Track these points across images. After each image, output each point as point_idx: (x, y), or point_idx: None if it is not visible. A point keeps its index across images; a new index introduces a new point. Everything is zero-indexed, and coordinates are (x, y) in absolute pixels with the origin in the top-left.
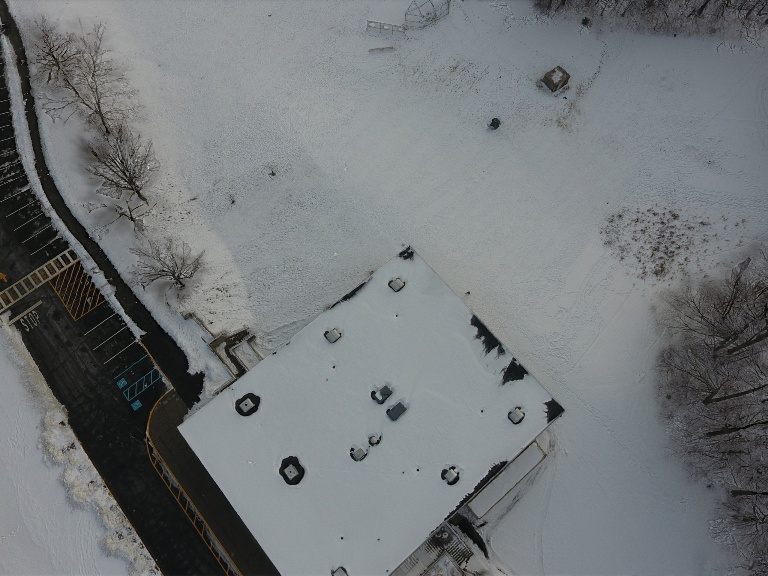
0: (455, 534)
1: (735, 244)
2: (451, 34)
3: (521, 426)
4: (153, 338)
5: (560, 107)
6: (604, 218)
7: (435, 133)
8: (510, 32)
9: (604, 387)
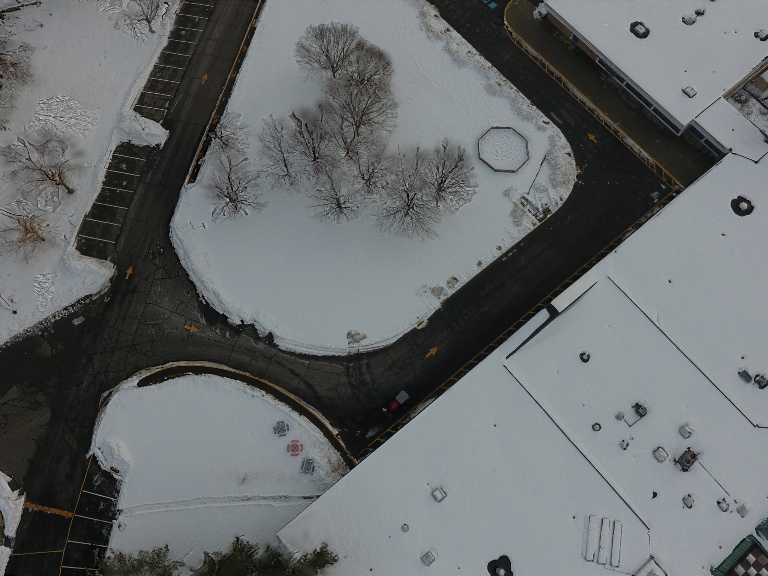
0: None
1: None
2: None
3: None
4: None
5: None
6: None
7: None
8: None
9: None
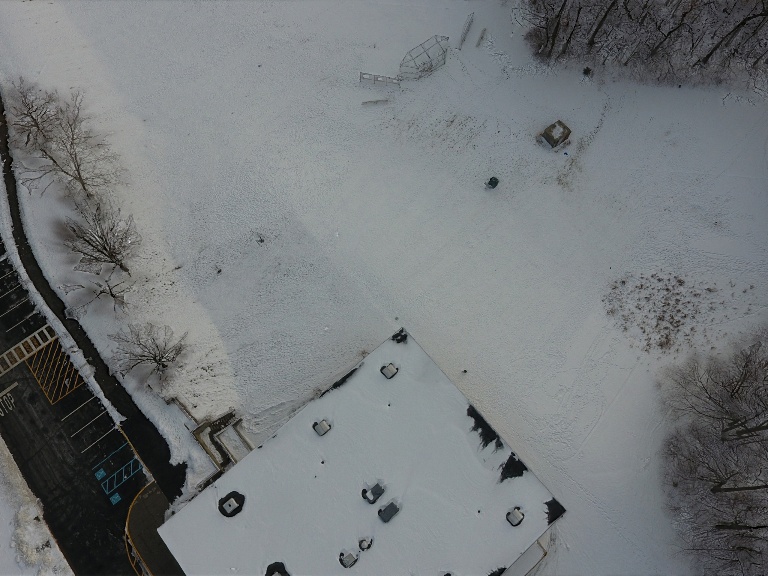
0: None
1: (743, 312)
2: (447, 85)
3: (520, 528)
4: (133, 424)
5: (561, 164)
6: (607, 284)
7: (431, 193)
8: (509, 83)
9: (607, 475)
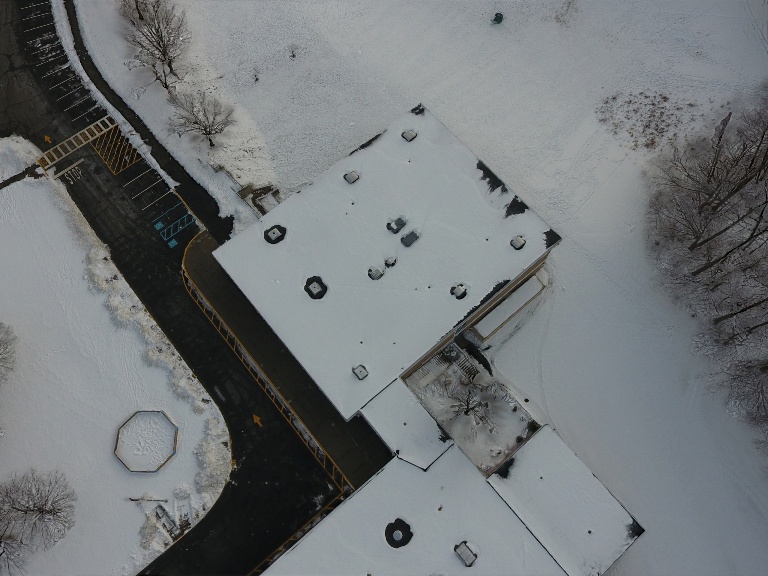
0: (462, 352)
1: None
2: None
3: (522, 251)
4: (186, 188)
5: (559, 5)
6: (599, 100)
7: (443, 26)
8: None
9: (598, 235)
